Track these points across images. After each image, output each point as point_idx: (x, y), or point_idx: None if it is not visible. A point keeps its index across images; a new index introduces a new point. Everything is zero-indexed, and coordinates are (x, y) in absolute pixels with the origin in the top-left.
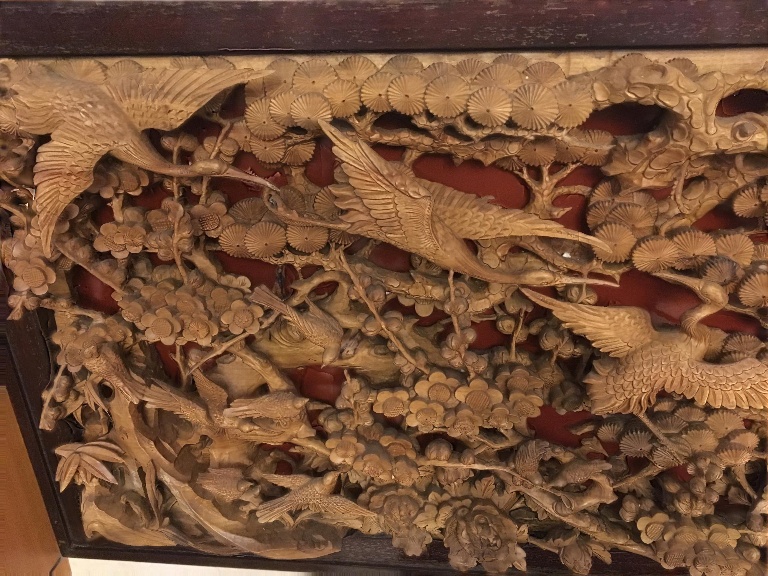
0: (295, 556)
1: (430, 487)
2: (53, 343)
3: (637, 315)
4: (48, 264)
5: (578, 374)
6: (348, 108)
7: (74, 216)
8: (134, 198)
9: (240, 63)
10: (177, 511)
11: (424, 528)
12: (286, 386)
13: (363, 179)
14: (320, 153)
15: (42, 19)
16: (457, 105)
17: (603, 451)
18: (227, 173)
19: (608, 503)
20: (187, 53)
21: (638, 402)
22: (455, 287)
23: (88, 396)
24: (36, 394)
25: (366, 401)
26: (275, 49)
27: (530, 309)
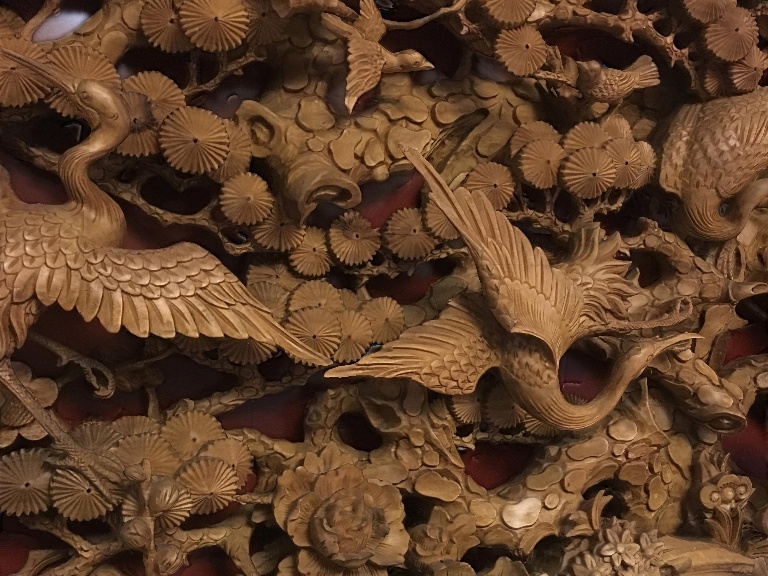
0: None
1: None
2: None
3: None
4: None
5: None
6: None
7: None
8: None
9: None
10: None
11: None
12: None
13: None
14: None
15: None
16: None
17: None
18: None
19: None
20: None
21: None
22: None
23: None
24: None
25: None
26: None
27: None
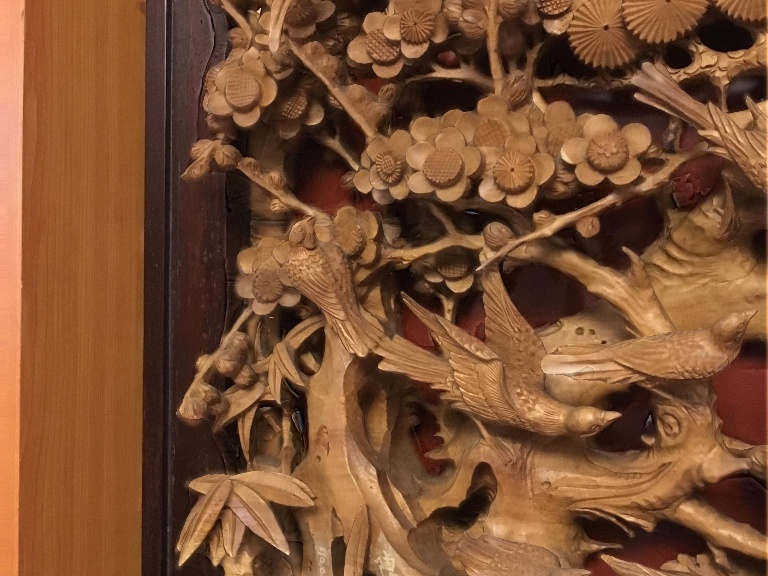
0: None
1: None
2: (237, 290)
3: None
4: (269, 73)
5: None
6: None
7: (326, 17)
8: None
9: None
10: None
11: None
12: None
13: None
14: None
15: None
16: None
17: None
18: None
19: None
20: None
21: None
22: None
23: (273, 374)
24: (187, 383)
25: None
26: None
27: None
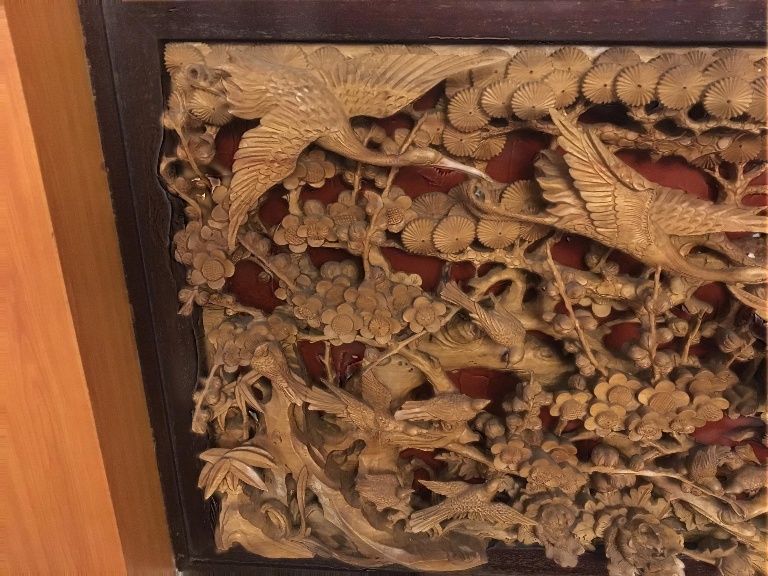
0: (444, 568)
1: (581, 496)
2: (202, 343)
3: None
4: (228, 257)
5: (747, 378)
6: (565, 99)
7: (253, 208)
8: (314, 190)
9: (443, 53)
10: (312, 521)
11: (578, 538)
12: (453, 388)
13: (585, 170)
14: (512, 147)
15: (248, 2)
16: (692, 96)
17: (755, 459)
18: (441, 162)
19: None
20: (393, 41)
21: None
22: (660, 284)
23: (239, 398)
24: (180, 396)
25: (541, 404)
26: (489, 38)
27: (711, 310)
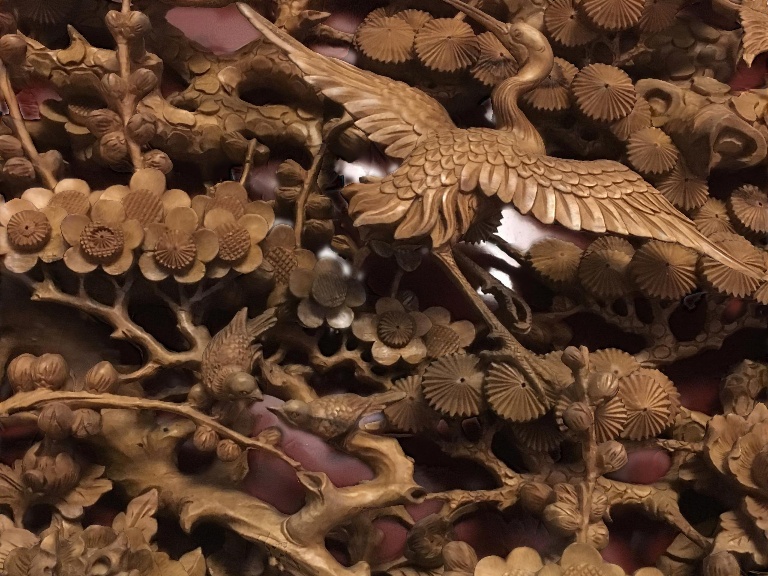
0: None
1: None
2: None
3: (425, 94)
4: None
5: None
6: None
7: None
8: None
9: None
10: None
11: None
12: None
13: None
14: None
15: None
16: None
17: (404, 514)
18: None
19: (403, 492)
20: None
21: (438, 210)
22: None
23: None
24: None
25: None
26: None
27: (262, 148)
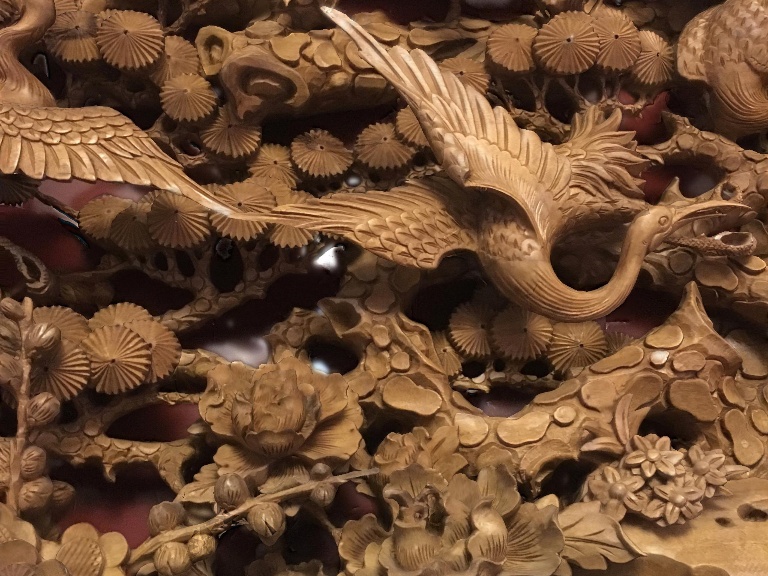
0: None
1: None
2: None
3: None
4: None
5: None
6: None
7: None
8: None
9: None
10: None
11: None
12: None
13: None
14: None
15: None
16: None
17: None
18: None
19: None
20: None
21: None
22: None
23: None
24: None
25: None
26: None
27: None
